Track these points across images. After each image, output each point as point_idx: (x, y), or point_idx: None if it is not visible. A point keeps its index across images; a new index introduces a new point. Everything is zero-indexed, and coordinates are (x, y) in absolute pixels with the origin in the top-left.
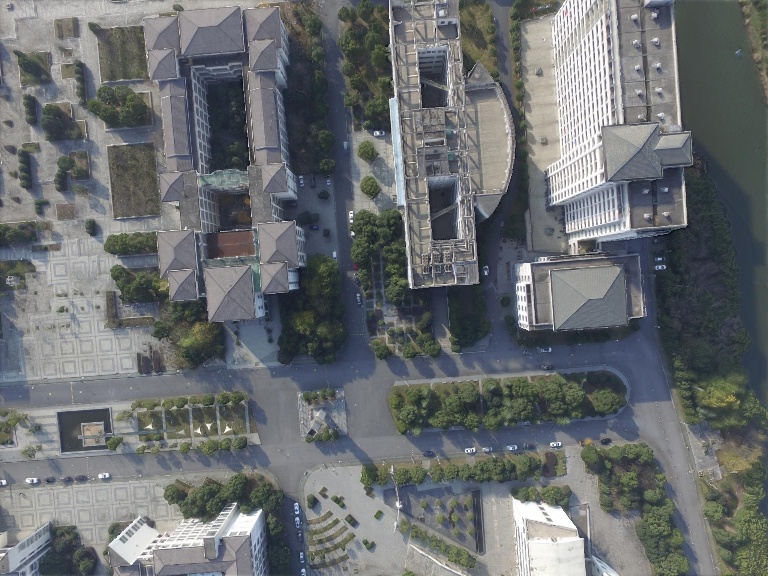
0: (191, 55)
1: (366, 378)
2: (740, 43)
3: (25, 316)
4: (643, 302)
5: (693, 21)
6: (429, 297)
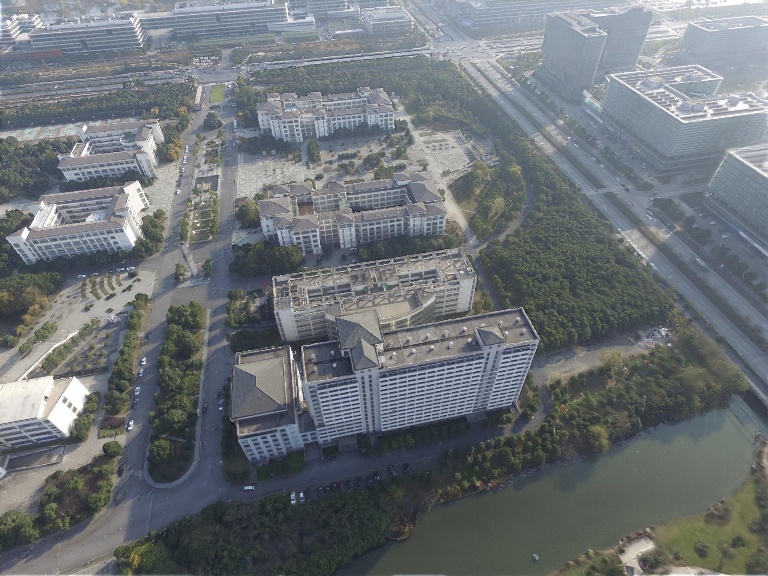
0: (410, 186)
1: (216, 293)
2: (551, 569)
3: (272, 162)
4: (252, 435)
5: (552, 506)
6: (272, 318)
